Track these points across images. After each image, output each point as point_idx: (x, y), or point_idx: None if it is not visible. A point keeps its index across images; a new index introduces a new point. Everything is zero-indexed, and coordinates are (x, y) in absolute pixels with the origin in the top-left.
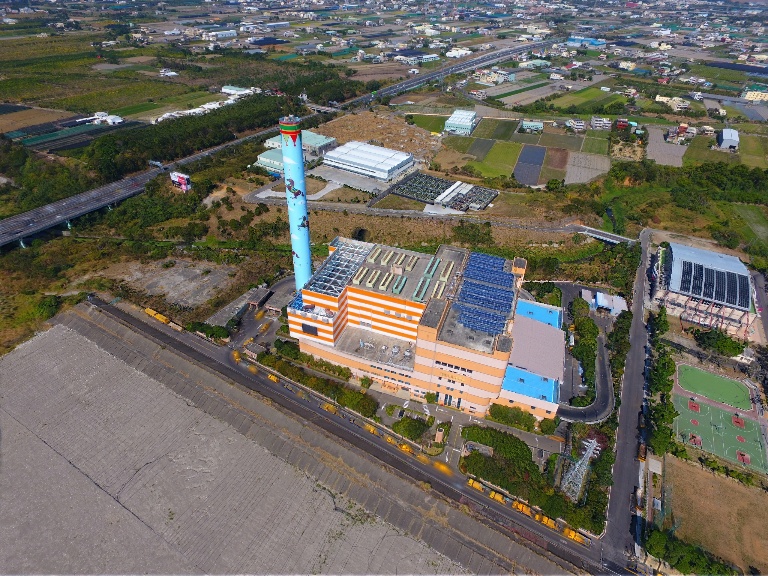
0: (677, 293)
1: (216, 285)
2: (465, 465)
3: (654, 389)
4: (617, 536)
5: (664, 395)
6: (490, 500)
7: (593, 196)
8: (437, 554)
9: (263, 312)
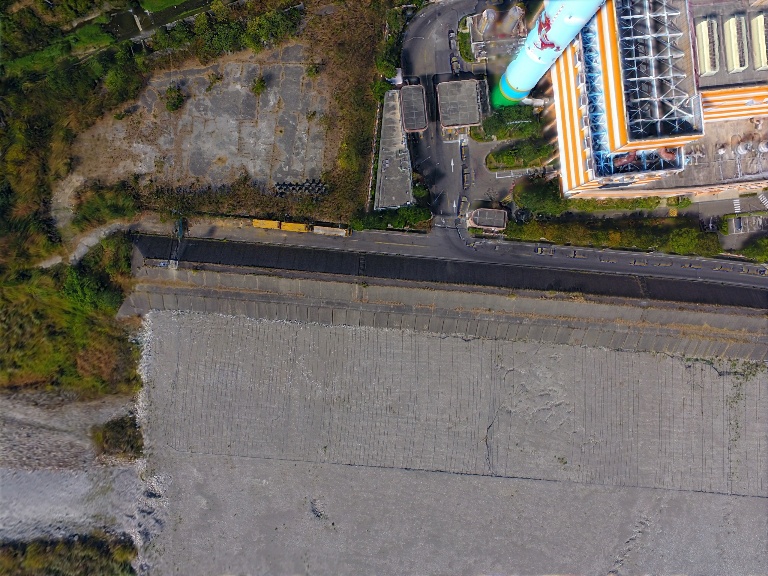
0: None
1: (305, 108)
2: None
3: None
4: None
5: None
6: None
7: None
8: None
9: (435, 133)
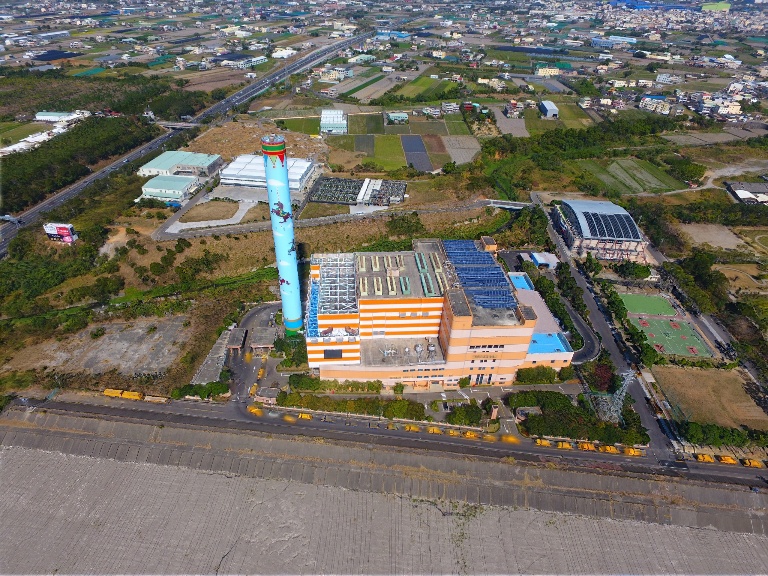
0: (589, 239)
1: (174, 340)
2: (525, 430)
3: (618, 318)
4: (657, 440)
5: (622, 321)
6: (560, 451)
7: (481, 172)
8: (548, 513)
9: (248, 353)
